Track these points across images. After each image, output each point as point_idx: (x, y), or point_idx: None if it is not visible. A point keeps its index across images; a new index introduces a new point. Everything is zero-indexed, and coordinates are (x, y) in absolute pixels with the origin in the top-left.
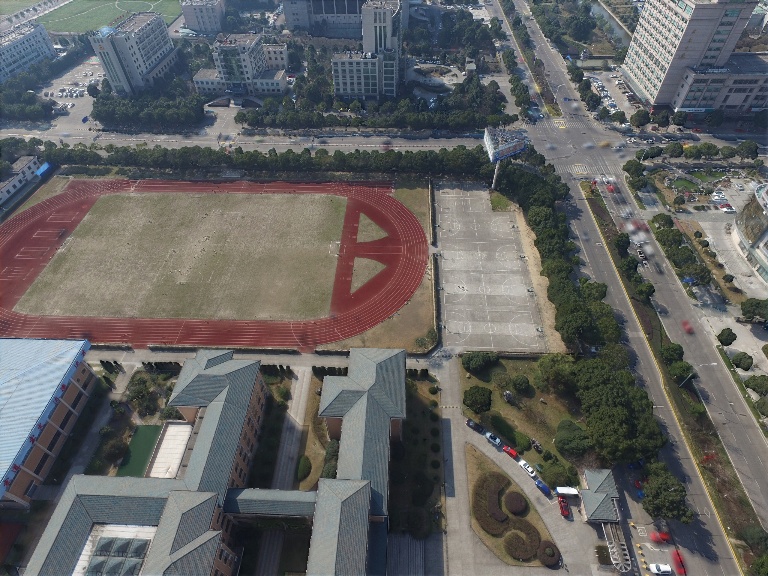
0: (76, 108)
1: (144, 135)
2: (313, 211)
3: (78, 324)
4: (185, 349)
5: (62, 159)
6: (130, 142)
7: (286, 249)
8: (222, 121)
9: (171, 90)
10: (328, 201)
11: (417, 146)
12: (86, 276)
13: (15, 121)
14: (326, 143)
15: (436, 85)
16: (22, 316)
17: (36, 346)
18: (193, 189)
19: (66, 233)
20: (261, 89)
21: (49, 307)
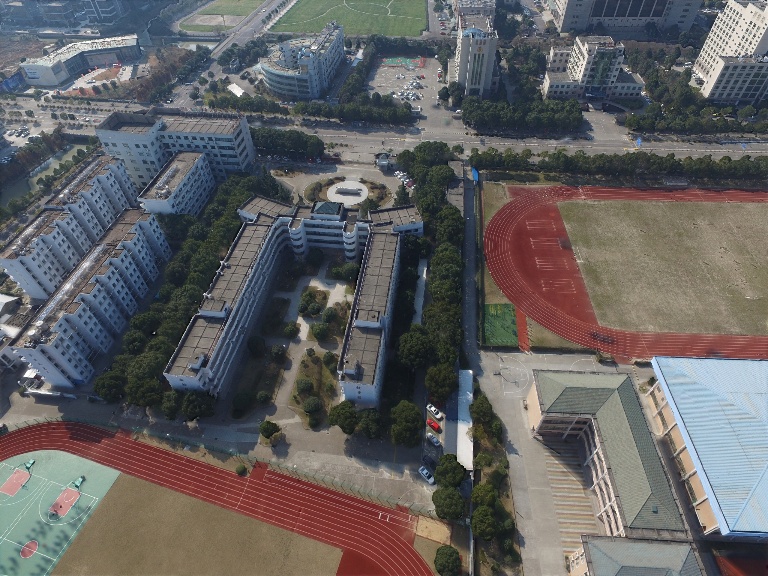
0: (427, 111)
1: (531, 140)
2: None
3: (690, 341)
4: None
5: (489, 164)
6: (524, 147)
7: None
8: (599, 126)
9: (530, 93)
10: None
11: None
12: (639, 289)
13: (375, 124)
14: (737, 150)
15: None
16: (618, 332)
17: None
18: (649, 197)
19: (565, 243)
20: (618, 93)
21: (637, 322)
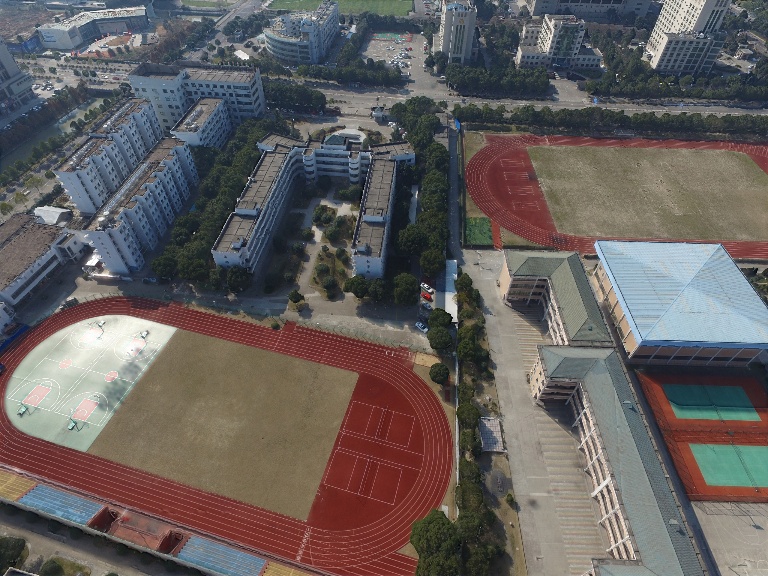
0: (415, 76)
1: (505, 100)
2: (728, 163)
3: None
4: (743, 261)
5: (469, 116)
6: None
7: (739, 190)
8: (563, 90)
9: None
10: (732, 155)
11: (760, 114)
12: (591, 208)
13: (369, 86)
14: (677, 110)
15: (722, 66)
16: (573, 237)
17: (686, 247)
18: (602, 144)
19: (532, 176)
20: (581, 64)
21: (588, 230)
